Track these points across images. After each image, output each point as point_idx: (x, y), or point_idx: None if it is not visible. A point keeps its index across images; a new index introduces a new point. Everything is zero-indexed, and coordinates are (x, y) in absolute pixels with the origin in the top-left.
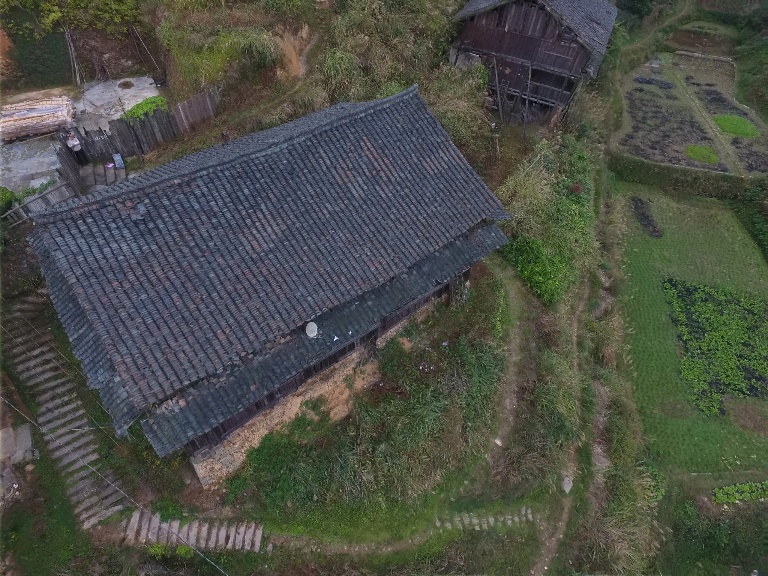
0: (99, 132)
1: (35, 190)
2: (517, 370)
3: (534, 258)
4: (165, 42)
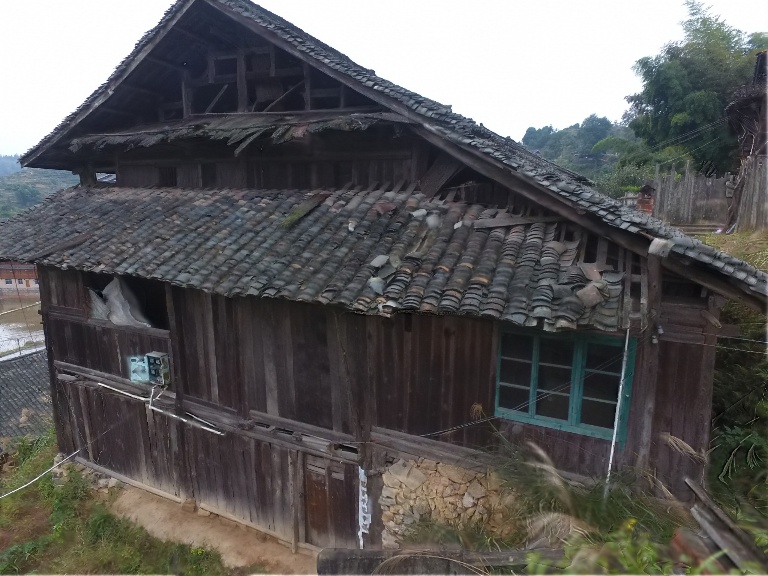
0: None
1: None
2: None
3: None
4: None
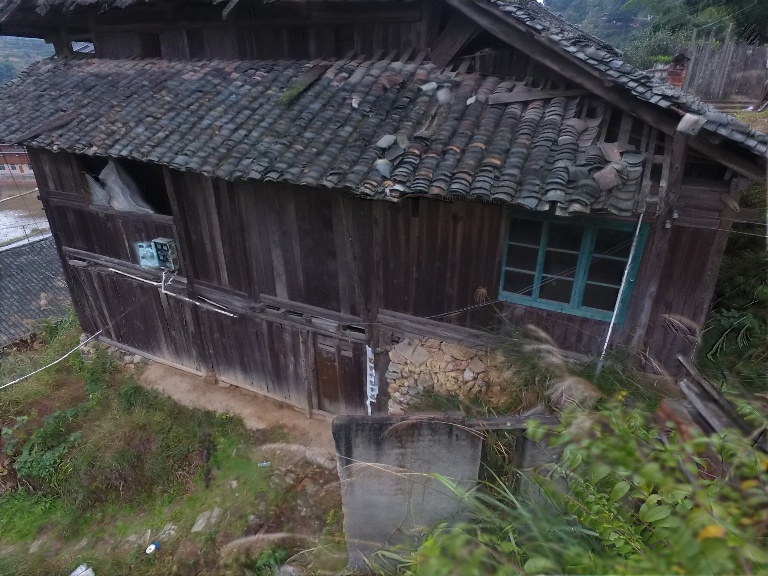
0: None
1: None
2: None
3: None
4: None
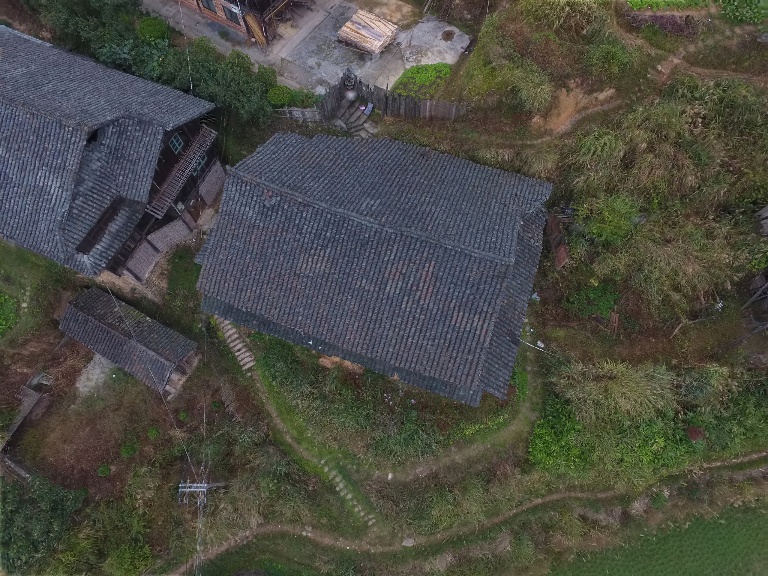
0: (367, 86)
1: (311, 97)
2: (448, 464)
3: (560, 430)
4: (480, 34)
